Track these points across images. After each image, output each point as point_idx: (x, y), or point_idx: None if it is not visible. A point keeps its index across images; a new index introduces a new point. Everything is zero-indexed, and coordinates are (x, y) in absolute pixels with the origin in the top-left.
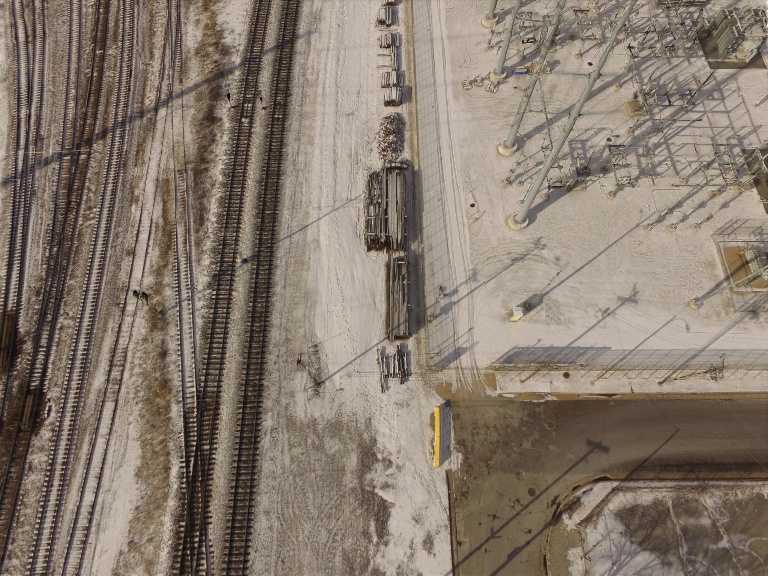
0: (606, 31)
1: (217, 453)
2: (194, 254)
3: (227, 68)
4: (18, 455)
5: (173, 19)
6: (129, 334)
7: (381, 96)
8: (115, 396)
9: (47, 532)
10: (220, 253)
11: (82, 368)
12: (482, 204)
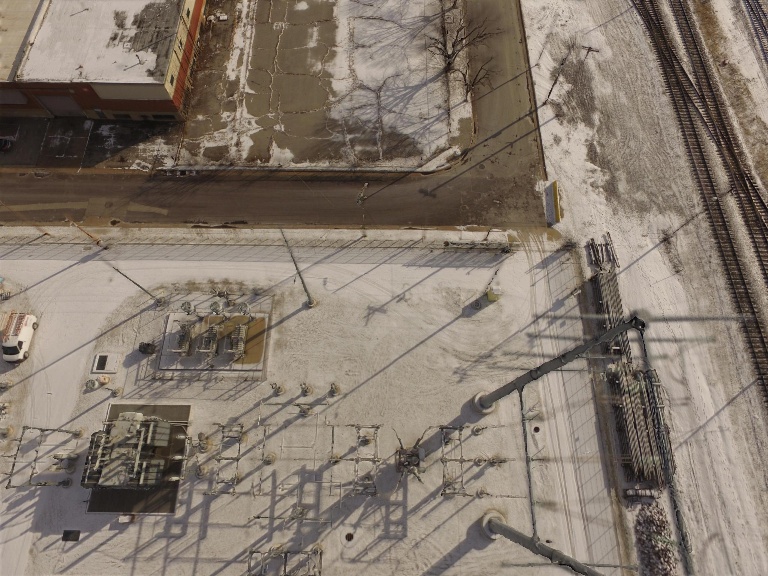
0: None
1: None
2: None
3: None
4: None
5: None
6: None
7: None
8: None
9: None
10: None
11: None
12: None
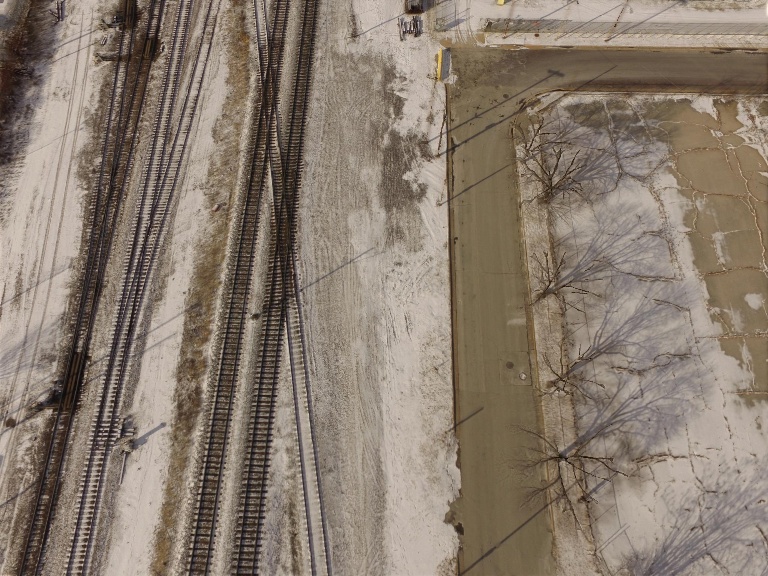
0: None
1: (283, 69)
2: None
3: None
4: (143, 71)
5: None
6: (217, 8)
7: None
8: (209, 41)
9: (166, 109)
10: None
11: (185, 26)
12: None
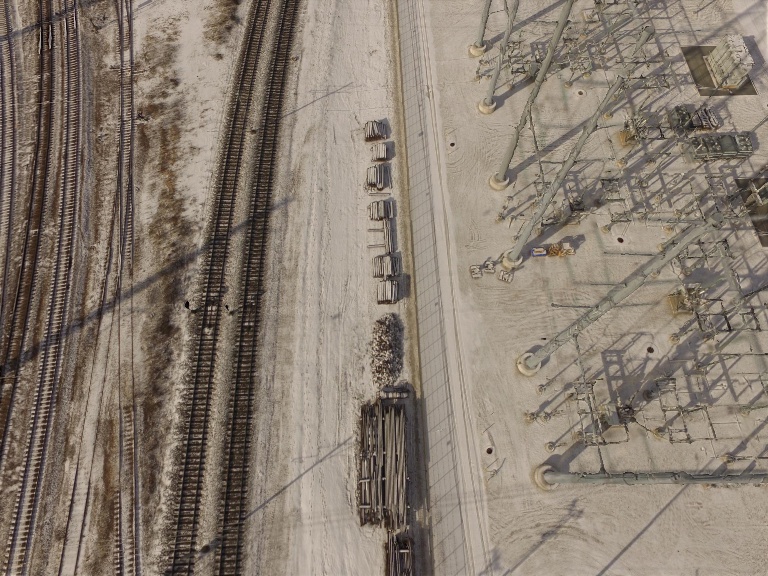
0: (636, 193)
1: None
2: (142, 538)
3: (187, 254)
4: None
5: (124, 184)
6: None
7: (373, 289)
8: None
9: None
10: (175, 537)
11: None
12: (501, 449)
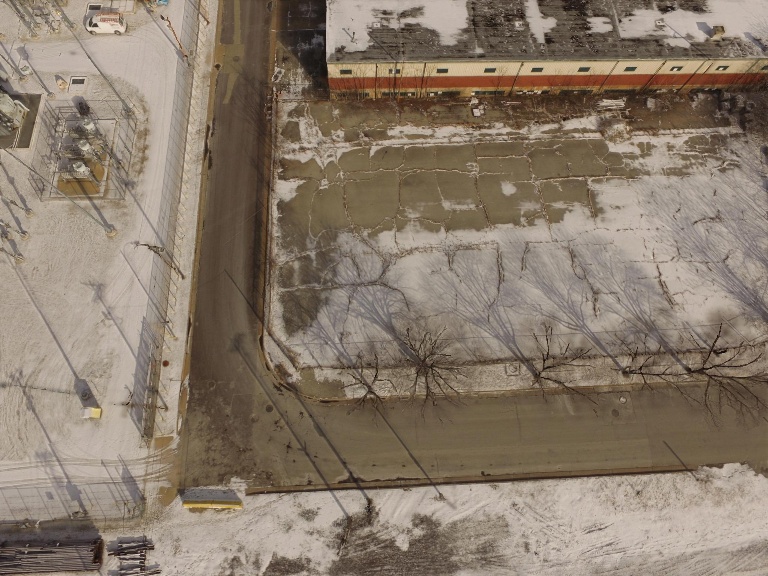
0: None
1: None
2: None
3: None
4: None
5: None
6: None
7: None
8: None
9: None
10: None
11: None
12: None
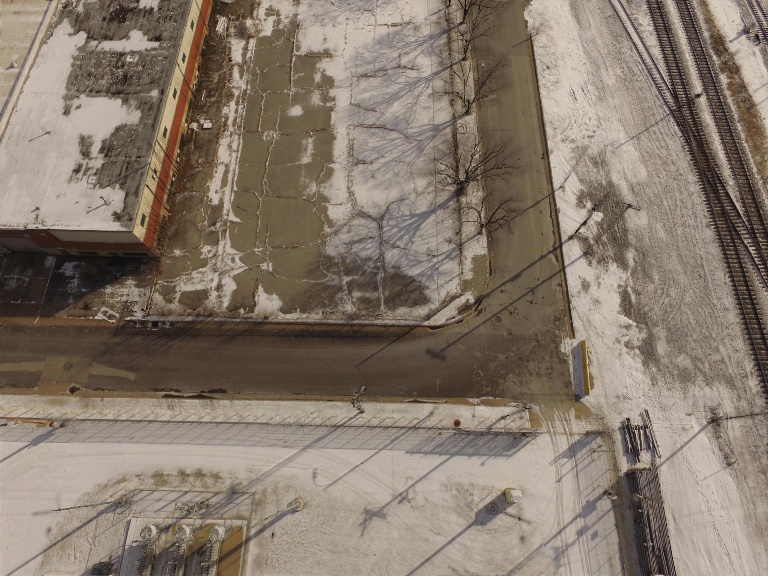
0: None
1: None
2: None
3: None
4: None
5: None
6: None
7: None
8: None
9: None
10: None
11: None
12: None
